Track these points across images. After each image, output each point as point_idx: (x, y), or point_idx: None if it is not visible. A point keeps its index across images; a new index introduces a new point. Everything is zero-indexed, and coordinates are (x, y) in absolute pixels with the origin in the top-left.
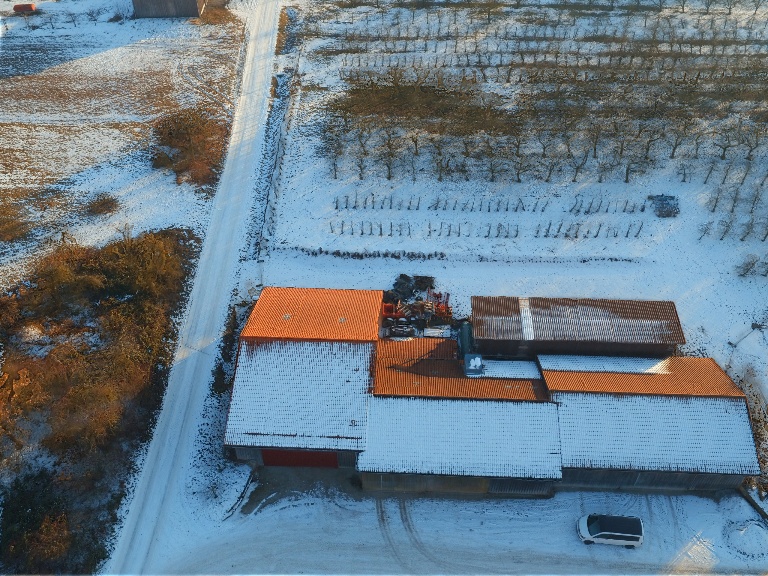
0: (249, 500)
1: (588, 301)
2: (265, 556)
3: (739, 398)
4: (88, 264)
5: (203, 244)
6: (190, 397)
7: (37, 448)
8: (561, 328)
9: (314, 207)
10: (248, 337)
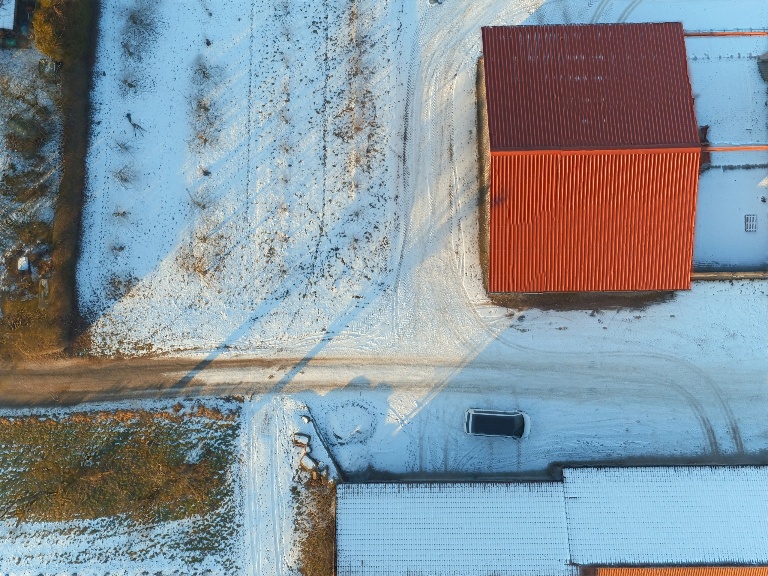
0: None
1: None
2: None
3: None
4: None
5: None
6: None
7: None
8: None
9: None
10: None
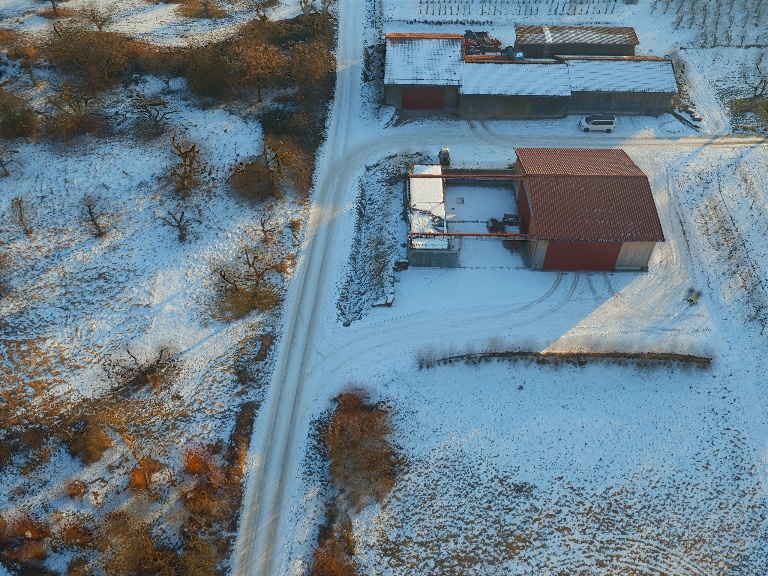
0: (396, 122)
1: (583, 27)
2: (410, 140)
3: (668, 60)
4: (273, 25)
5: (339, 21)
6: (351, 84)
7: (270, 102)
8: (568, 38)
9: (406, 3)
10: (390, 37)
